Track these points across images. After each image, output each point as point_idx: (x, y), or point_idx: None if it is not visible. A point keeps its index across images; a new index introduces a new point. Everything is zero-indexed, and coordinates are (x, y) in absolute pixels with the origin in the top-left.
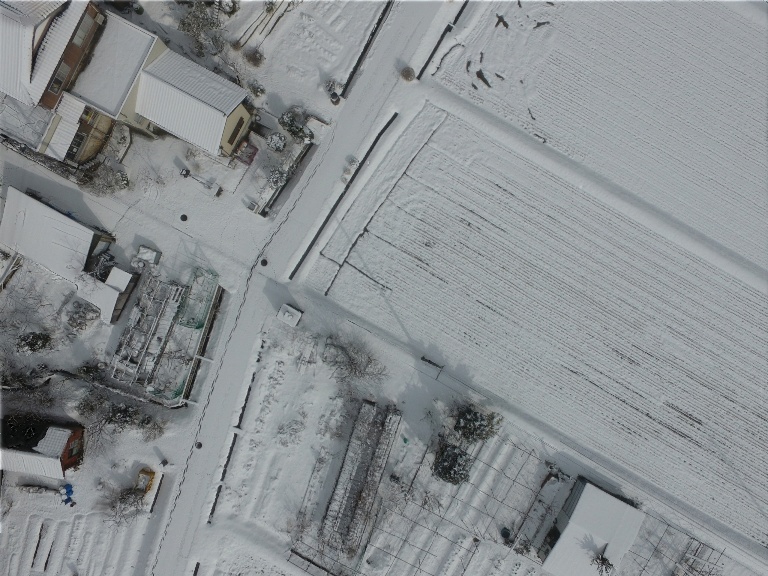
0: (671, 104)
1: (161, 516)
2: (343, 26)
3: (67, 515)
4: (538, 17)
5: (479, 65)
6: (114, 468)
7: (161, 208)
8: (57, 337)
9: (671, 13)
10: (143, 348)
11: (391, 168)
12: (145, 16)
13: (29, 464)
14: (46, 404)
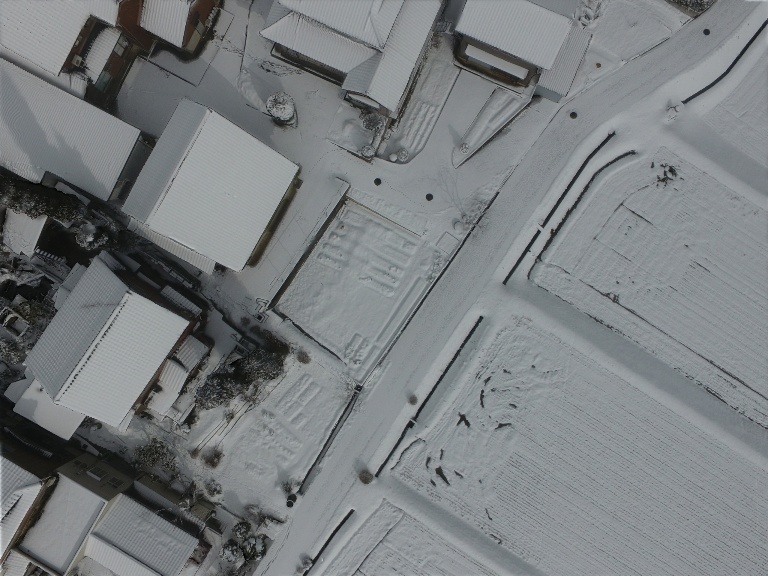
0: (628, 514)
1: None
2: (304, 423)
3: None
4: (500, 418)
5: (439, 462)
6: None
7: None
8: None
9: (633, 424)
10: None
11: (345, 564)
12: (103, 430)
13: None
14: None
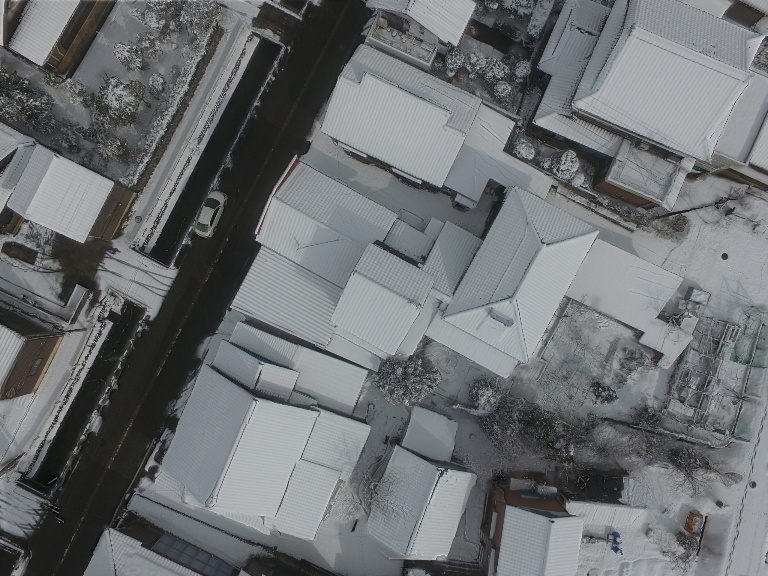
0: None
1: (719, 559)
2: None
3: (614, 563)
4: None
5: None
6: (667, 513)
7: (702, 248)
8: (608, 385)
9: None
10: (700, 390)
11: None
12: None
13: (599, 515)
14: (604, 453)
